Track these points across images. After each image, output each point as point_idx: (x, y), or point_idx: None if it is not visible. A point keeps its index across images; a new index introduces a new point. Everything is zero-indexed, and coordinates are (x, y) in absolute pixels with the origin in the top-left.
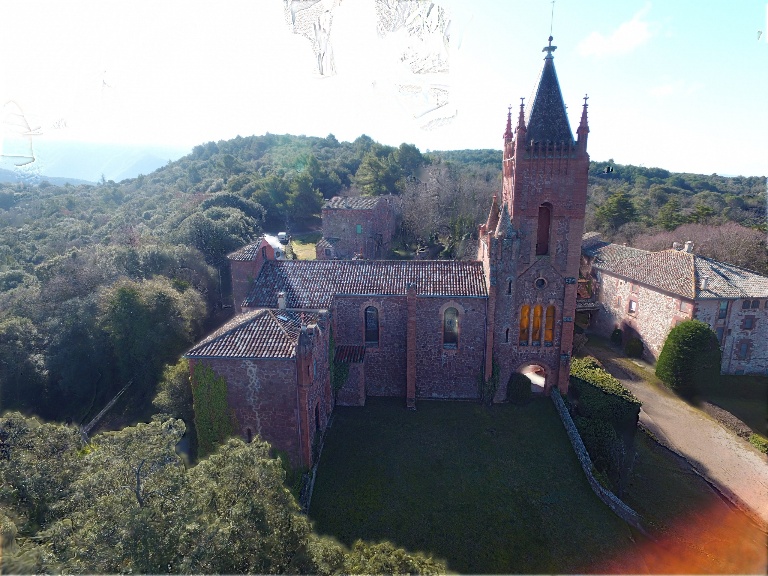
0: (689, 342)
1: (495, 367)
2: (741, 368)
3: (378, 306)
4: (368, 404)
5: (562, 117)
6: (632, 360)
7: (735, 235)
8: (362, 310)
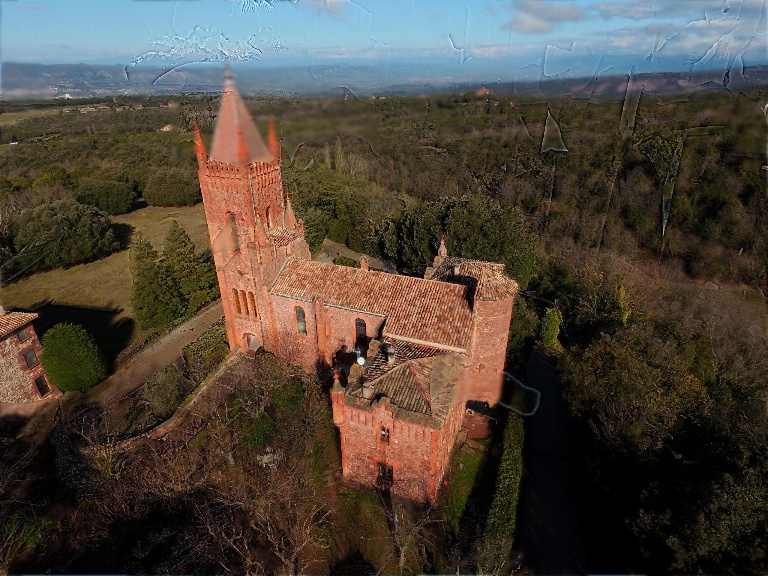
0: None
1: None
2: None
3: None
4: None
5: None
6: None
7: None
8: None
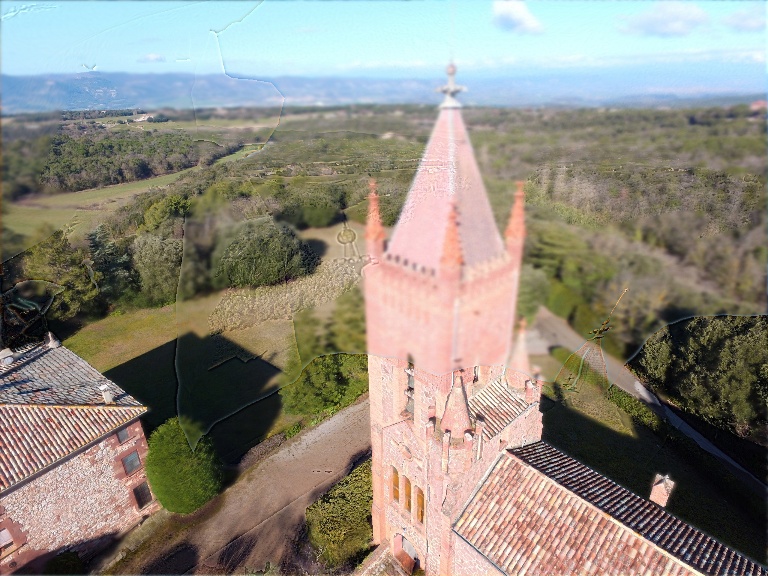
0: (205, 439)
1: None
2: None
3: None
4: None
5: None
6: (98, 573)
7: None
8: None
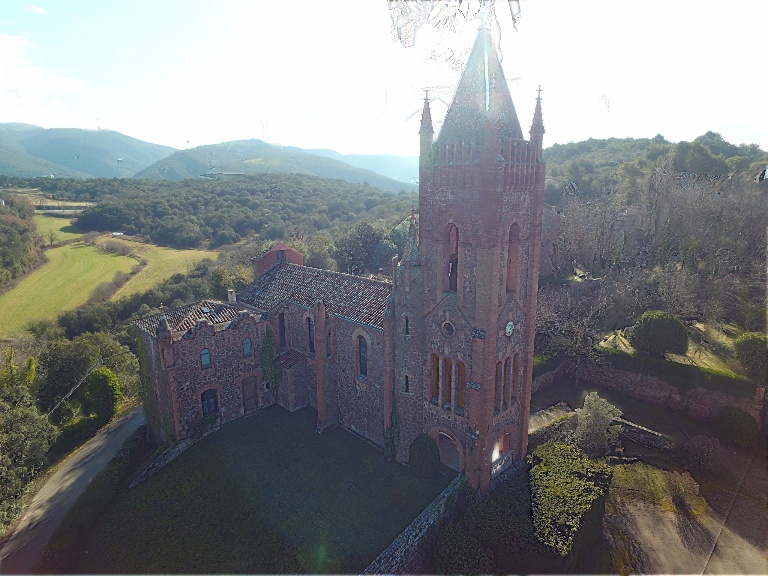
0: None
1: (393, 417)
2: None
3: (313, 319)
4: (297, 412)
5: (482, 107)
6: None
7: None
8: (304, 320)
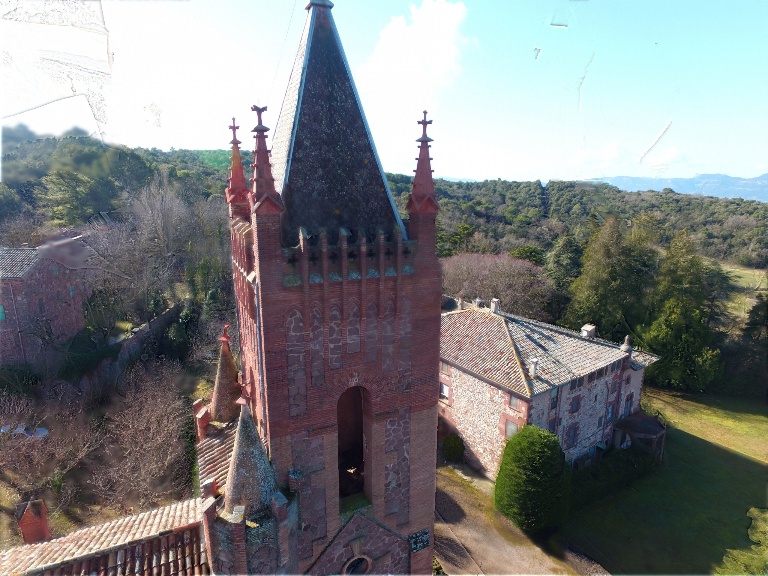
0: (538, 468)
1: None
2: (570, 457)
3: None
4: None
5: (369, 165)
6: (454, 468)
7: (510, 267)
8: None
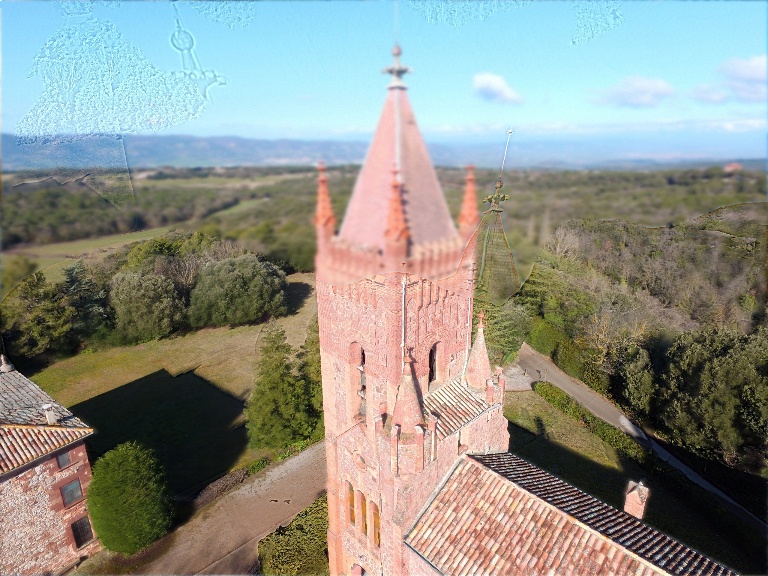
0: (156, 467)
1: None
2: None
3: None
4: None
5: None
6: None
7: None
8: None
